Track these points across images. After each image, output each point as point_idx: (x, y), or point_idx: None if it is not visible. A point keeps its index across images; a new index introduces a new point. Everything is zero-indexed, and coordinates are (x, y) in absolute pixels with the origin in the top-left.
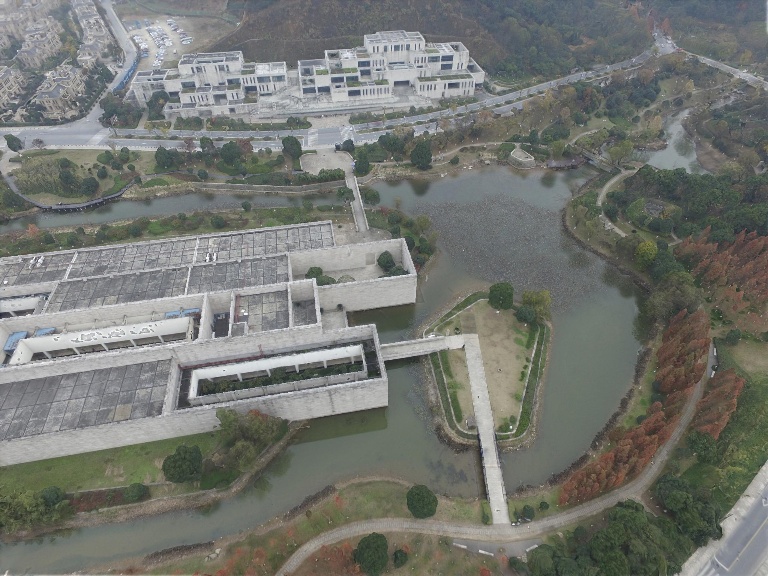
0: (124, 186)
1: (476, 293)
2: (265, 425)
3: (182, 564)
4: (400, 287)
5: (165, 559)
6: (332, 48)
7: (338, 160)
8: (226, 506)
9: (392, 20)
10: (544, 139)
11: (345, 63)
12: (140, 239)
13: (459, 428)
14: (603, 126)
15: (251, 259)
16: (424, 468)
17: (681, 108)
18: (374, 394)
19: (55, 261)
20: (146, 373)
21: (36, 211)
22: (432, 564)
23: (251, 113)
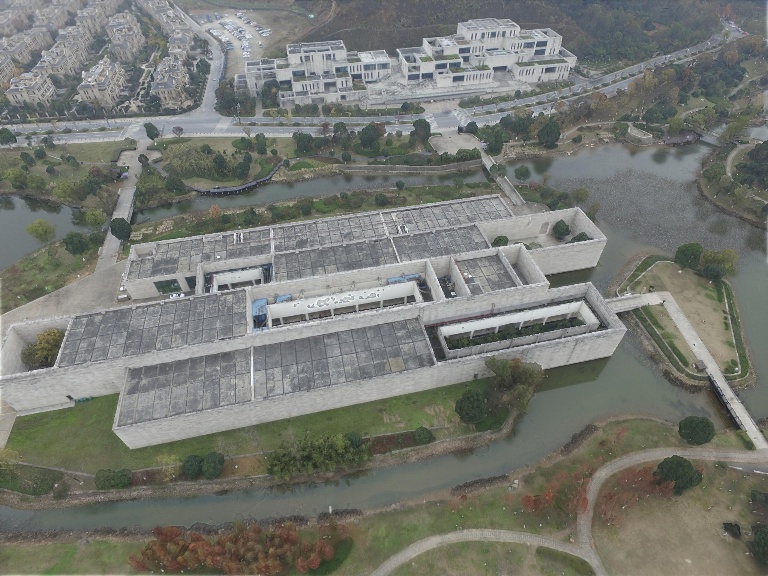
0: (271, 170)
1: (651, 256)
2: (536, 370)
3: (489, 494)
4: (589, 251)
5: (471, 490)
6: (423, 36)
7: (465, 141)
8: (503, 445)
9: (480, 8)
10: (655, 118)
11: (447, 50)
12: (312, 217)
13: (689, 371)
14: (702, 105)
15: (444, 230)
16: (667, 407)
17: (766, 87)
18: (608, 343)
19: (255, 237)
20: (400, 331)
21: (195, 195)
22: (718, 483)
23: (361, 100)
